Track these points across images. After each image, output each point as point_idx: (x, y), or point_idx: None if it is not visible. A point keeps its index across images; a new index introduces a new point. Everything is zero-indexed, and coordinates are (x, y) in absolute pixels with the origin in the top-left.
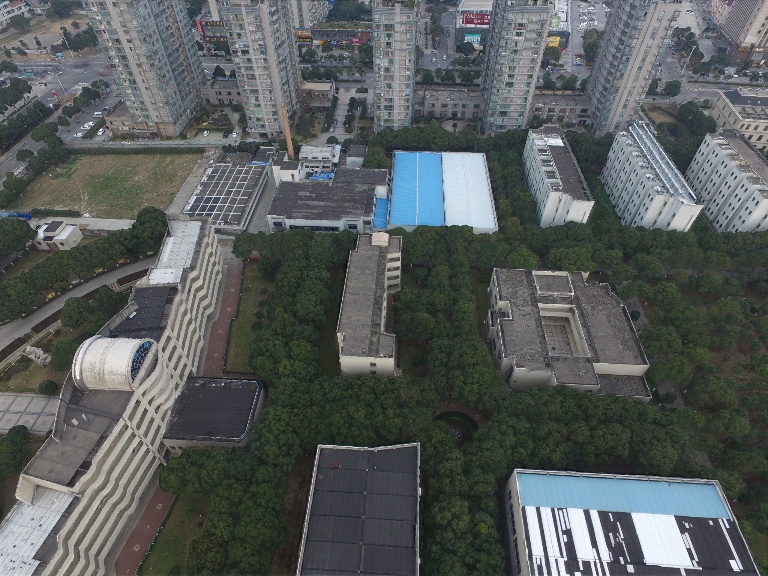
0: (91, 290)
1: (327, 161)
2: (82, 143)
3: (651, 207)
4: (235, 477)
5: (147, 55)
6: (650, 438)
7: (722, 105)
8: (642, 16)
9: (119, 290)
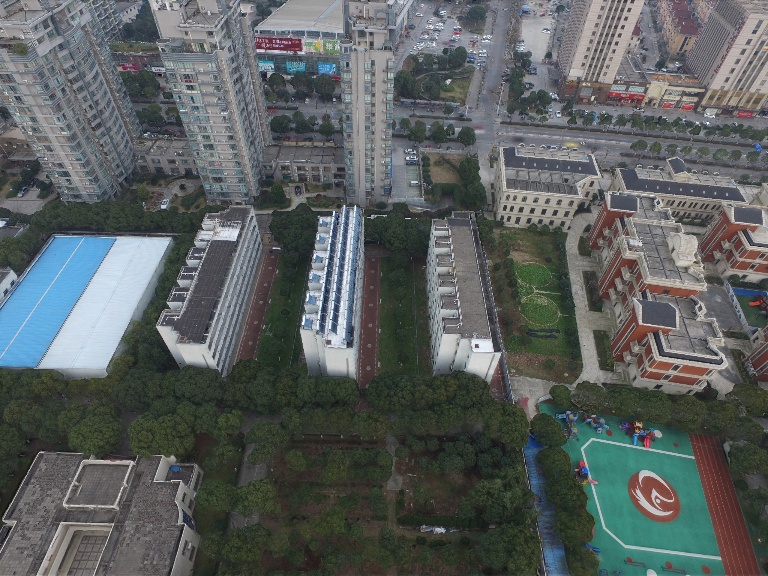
0: None
1: None
2: None
3: (303, 342)
4: None
5: None
6: None
7: (500, 165)
8: (344, 67)
9: None
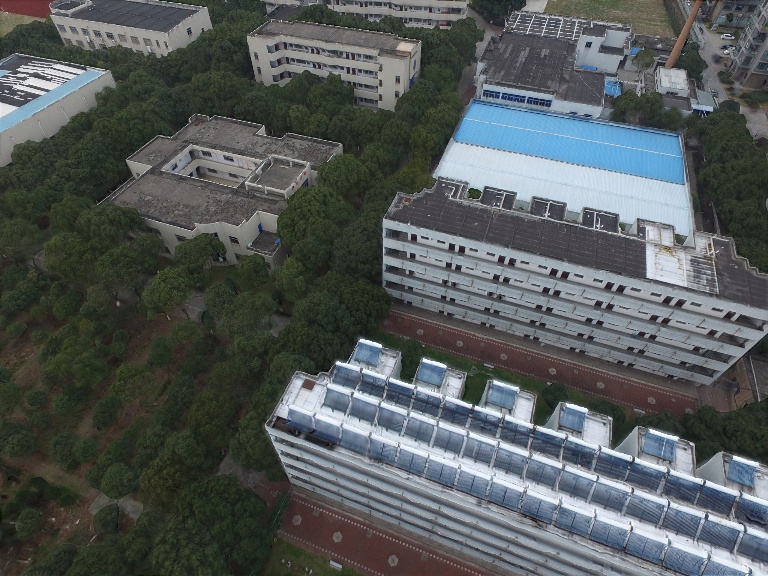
0: None
1: None
2: None
3: None
4: (225, 3)
5: None
6: (41, 143)
7: None
8: None
9: None
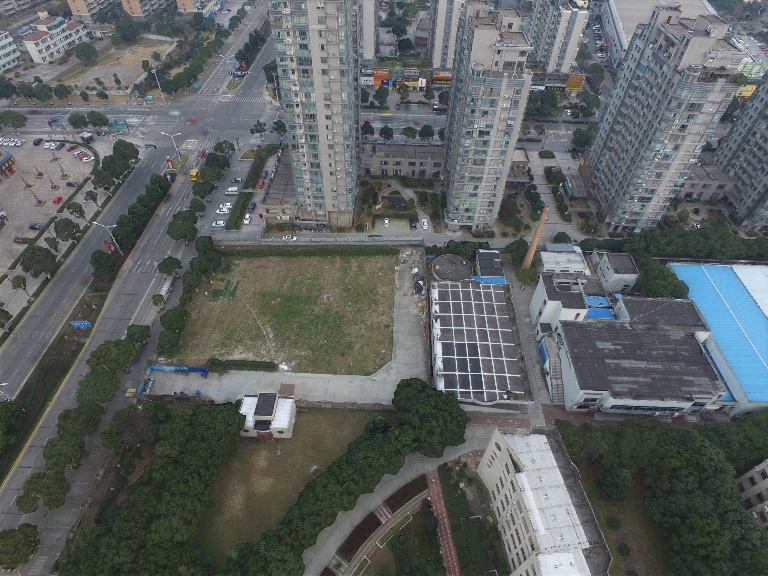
0: (352, 522)
1: (580, 275)
2: (228, 237)
3: None
4: None
5: (347, 134)
6: None
7: None
8: None
9: (396, 523)
